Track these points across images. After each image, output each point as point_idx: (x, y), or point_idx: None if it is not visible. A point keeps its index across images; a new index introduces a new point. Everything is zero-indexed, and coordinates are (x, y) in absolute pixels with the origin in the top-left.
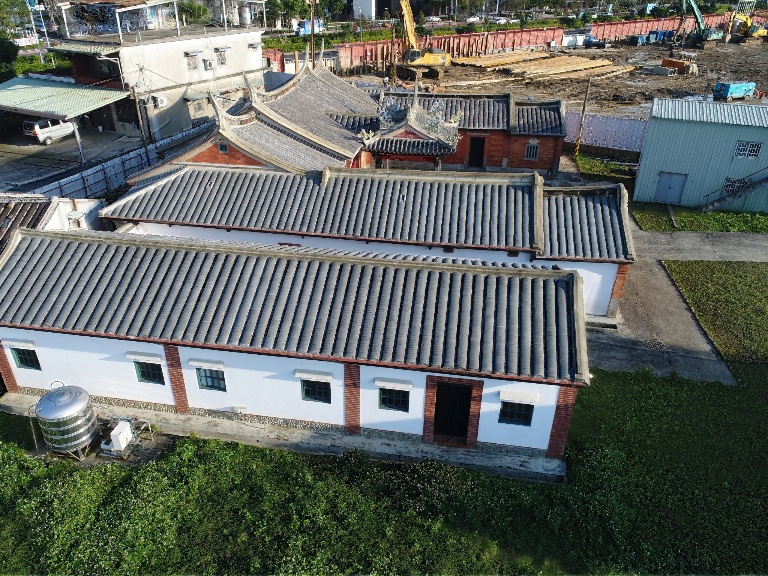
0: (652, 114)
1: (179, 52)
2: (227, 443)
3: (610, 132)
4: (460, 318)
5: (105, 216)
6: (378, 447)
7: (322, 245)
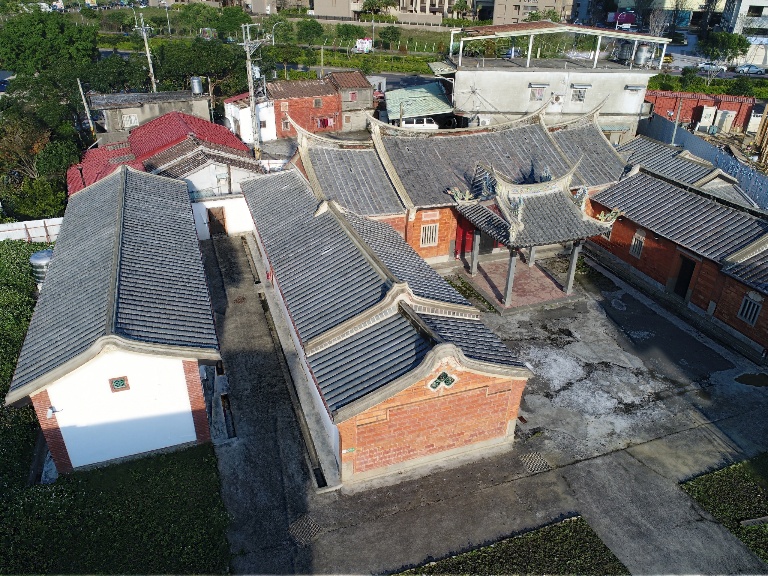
0: None
1: (524, 82)
2: None
3: None
4: None
5: (240, 184)
6: None
7: None
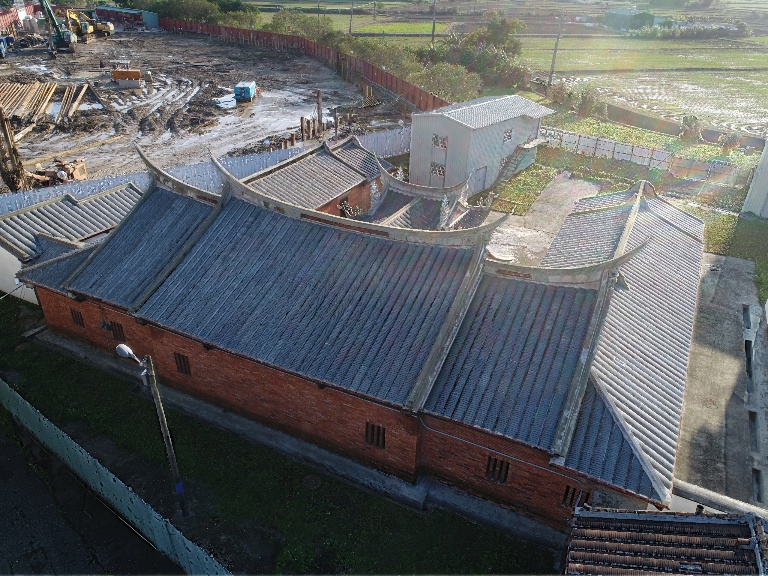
0: (472, 127)
1: None
2: None
3: None
4: None
5: None
6: None
7: None
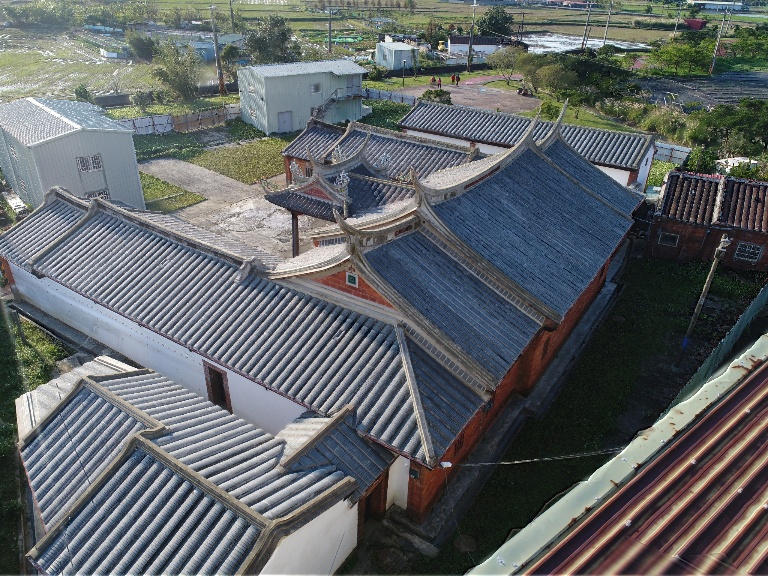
0: None
1: None
2: None
3: None
4: None
5: None
6: None
7: None
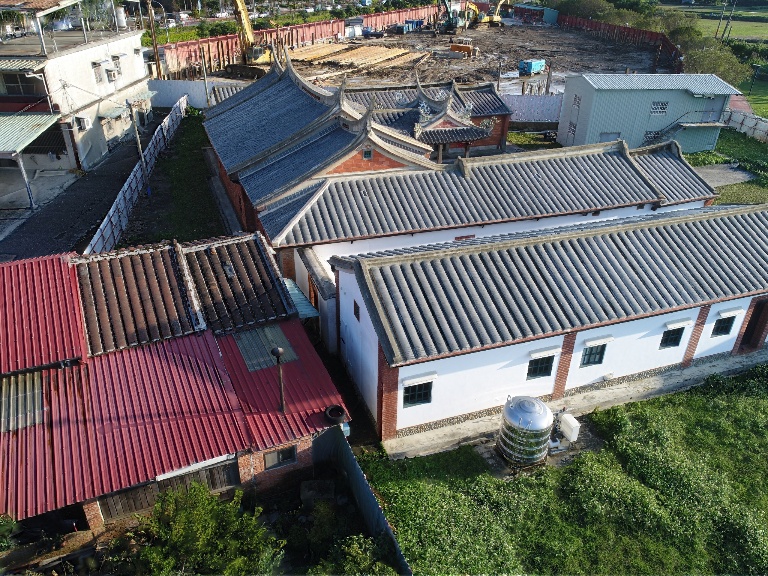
0: (595, 87)
1: (87, 62)
2: (626, 406)
3: (513, 108)
4: (762, 248)
5: (281, 246)
6: (711, 370)
7: (494, 231)
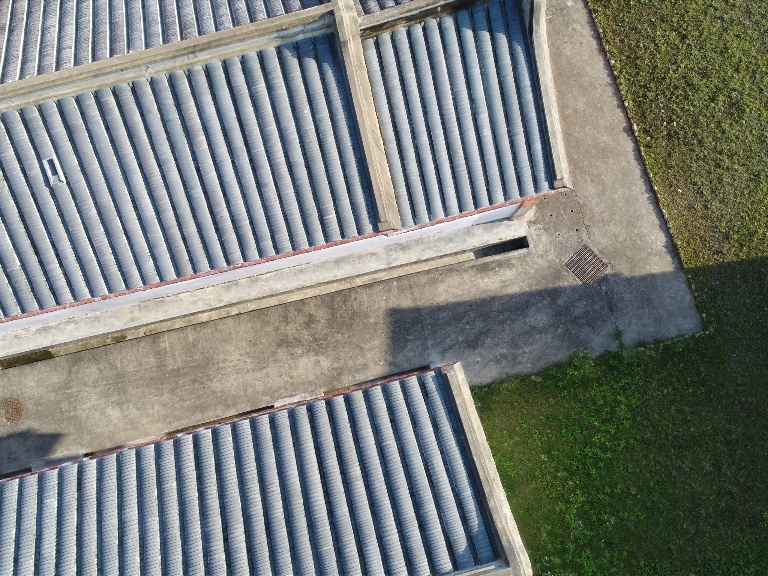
0: None
1: None
2: None
3: None
4: None
5: None
6: None
7: None
